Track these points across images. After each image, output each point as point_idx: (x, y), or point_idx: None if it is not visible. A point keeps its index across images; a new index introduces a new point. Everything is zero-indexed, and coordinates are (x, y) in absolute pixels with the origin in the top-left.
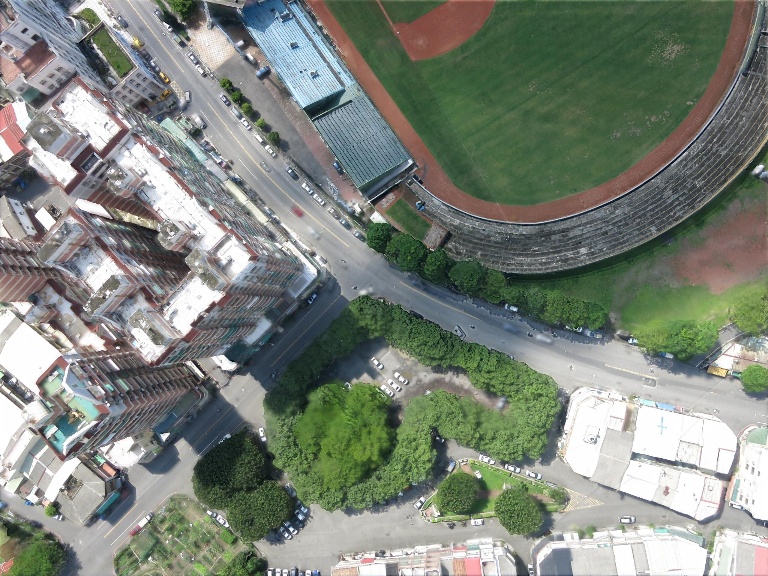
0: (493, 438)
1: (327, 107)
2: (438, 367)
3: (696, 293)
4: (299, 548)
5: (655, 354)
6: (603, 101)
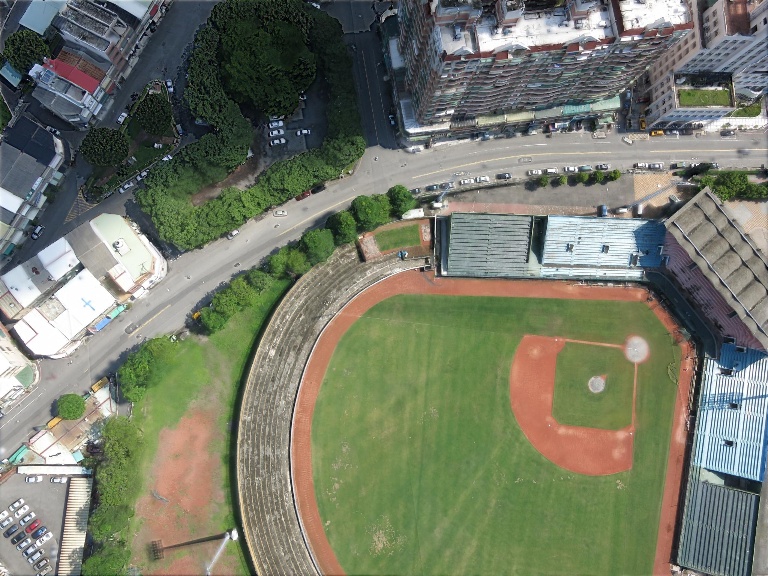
0: (176, 171)
1: (537, 241)
2: None
3: (174, 415)
4: None
5: None
6: (380, 458)
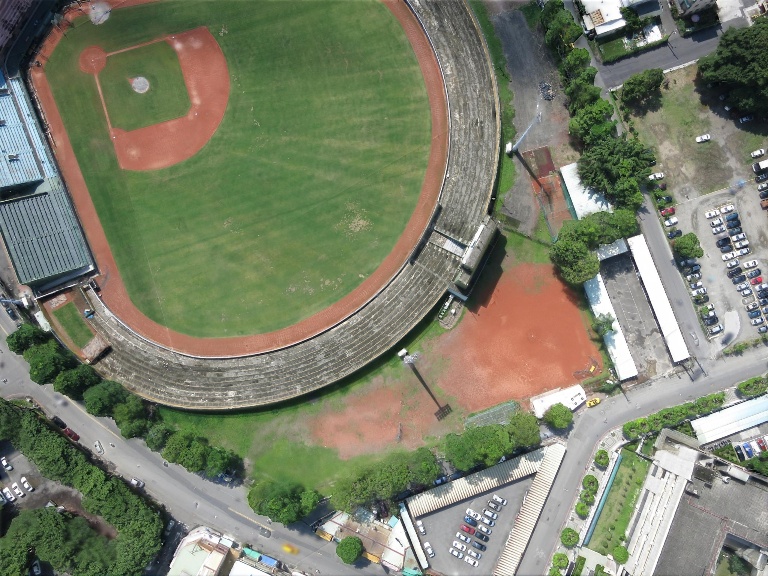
0: (87, 568)
1: (23, 192)
2: None
3: (326, 455)
4: None
5: None
6: (287, 254)
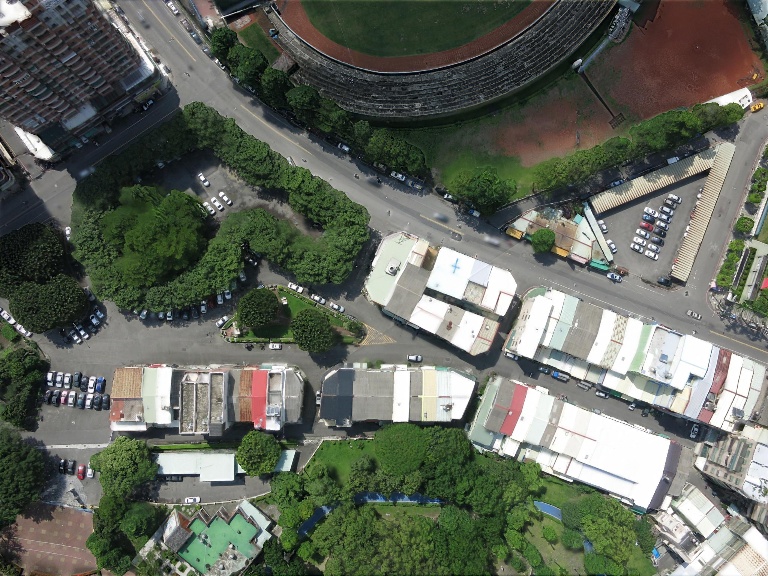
0: (301, 258)
1: None
2: (264, 193)
3: (509, 163)
4: (88, 354)
5: (465, 212)
6: None
